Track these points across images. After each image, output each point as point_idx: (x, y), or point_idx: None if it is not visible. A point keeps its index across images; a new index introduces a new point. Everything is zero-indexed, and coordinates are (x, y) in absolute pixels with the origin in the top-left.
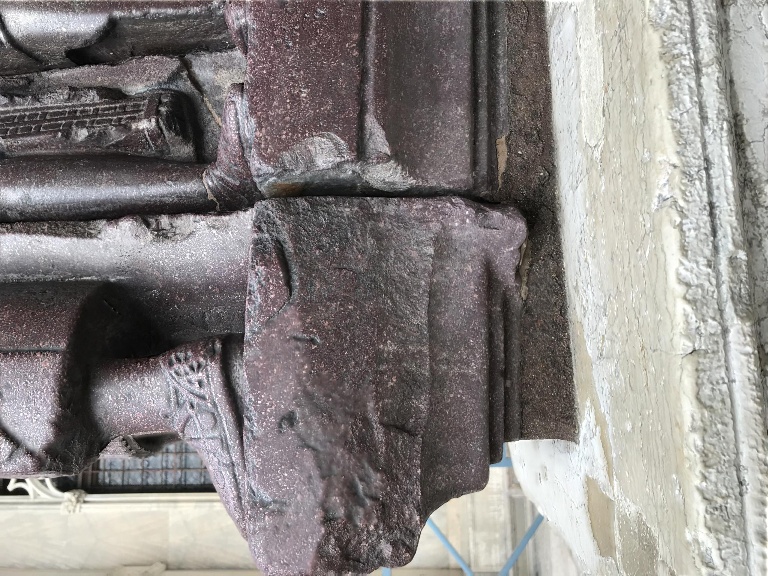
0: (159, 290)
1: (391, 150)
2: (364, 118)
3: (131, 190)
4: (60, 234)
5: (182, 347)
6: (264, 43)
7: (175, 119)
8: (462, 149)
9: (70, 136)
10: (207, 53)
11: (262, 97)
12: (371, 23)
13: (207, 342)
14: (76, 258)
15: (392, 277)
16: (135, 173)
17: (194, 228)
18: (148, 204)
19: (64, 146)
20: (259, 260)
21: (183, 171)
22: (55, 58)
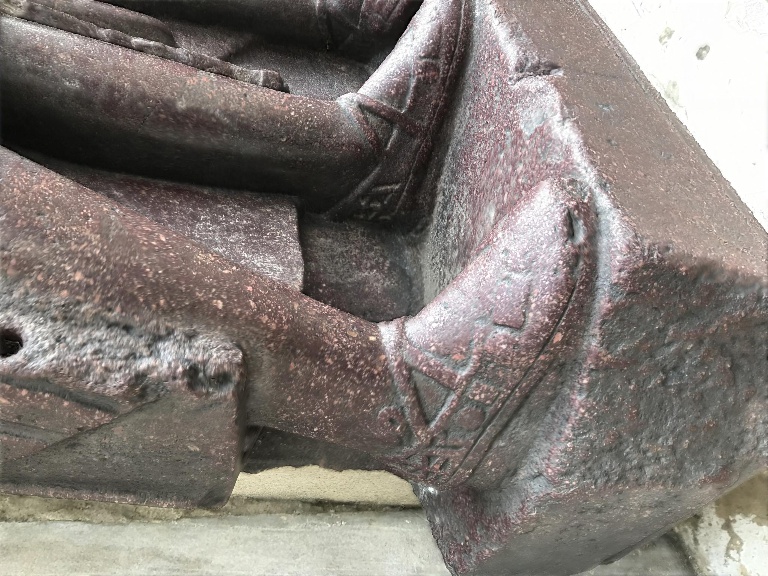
0: None
1: None
2: None
3: None
4: None
5: None
6: None
7: None
8: None
9: None
10: None
11: None
12: None
13: None
14: None
15: None
16: None
17: None
18: None
19: None
20: None
21: None
22: None
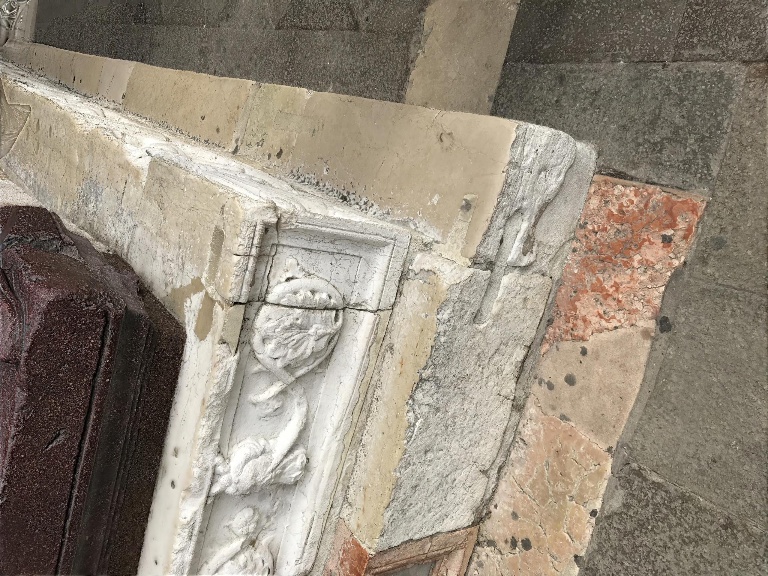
0: None
1: None
2: None
3: None
4: None
5: None
6: None
7: None
8: None
9: None
10: None
11: None
12: None
13: None
14: None
15: None
16: None
17: None
18: None
19: None
20: None
21: None
22: None
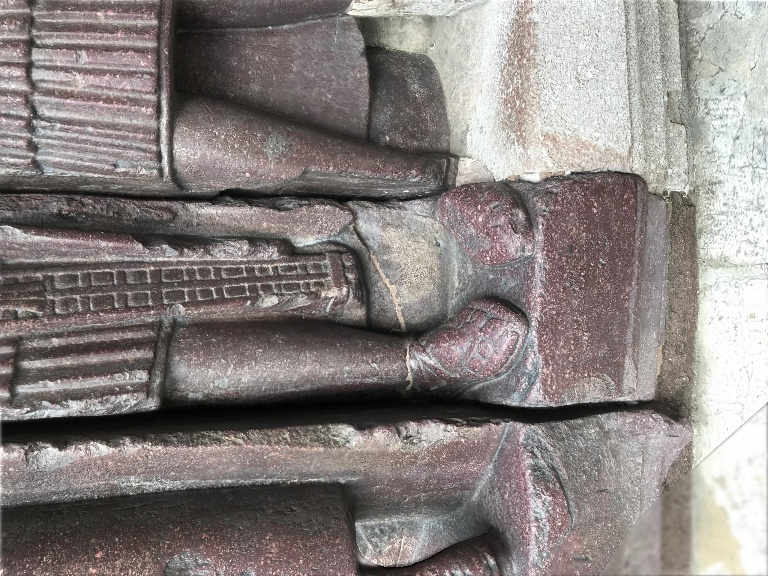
0: (382, 486)
1: (636, 385)
2: (624, 359)
3: (335, 372)
4: (306, 444)
5: (454, 564)
6: (555, 285)
7: (358, 285)
8: (654, 367)
9: (256, 303)
10: (375, 207)
11: (551, 336)
12: (634, 275)
13: (480, 558)
14: (313, 465)
15: (624, 489)
16: (339, 354)
17: (443, 436)
18: (347, 384)
19: (244, 312)
20: (545, 489)
21: (385, 352)
22: (204, 189)
